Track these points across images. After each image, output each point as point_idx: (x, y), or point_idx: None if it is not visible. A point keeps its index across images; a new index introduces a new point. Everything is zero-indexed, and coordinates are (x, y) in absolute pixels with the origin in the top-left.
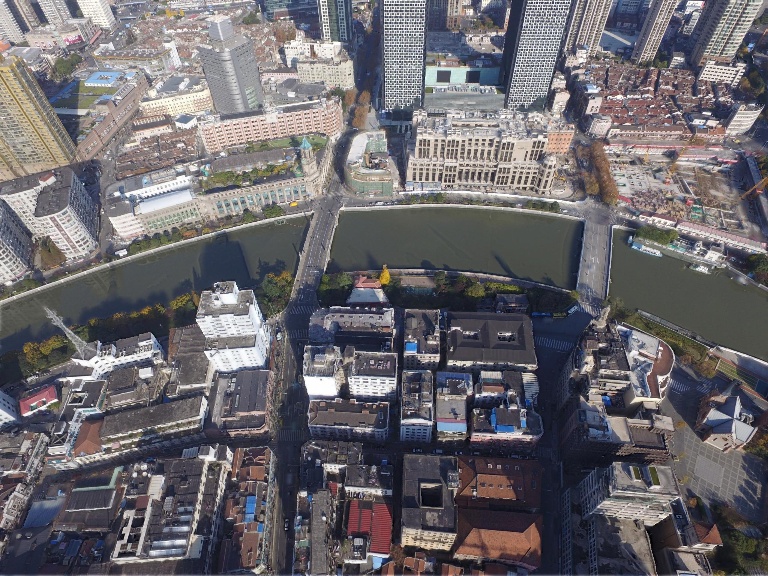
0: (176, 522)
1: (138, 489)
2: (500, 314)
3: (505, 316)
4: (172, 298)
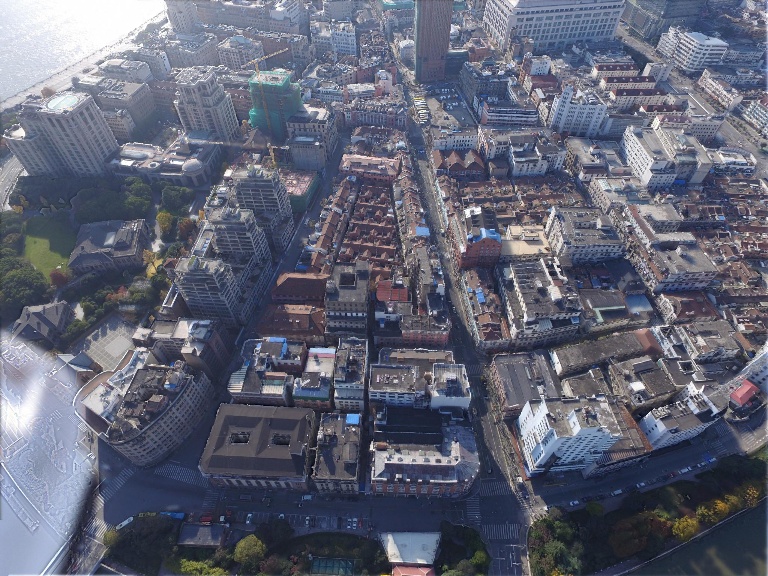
0: (527, 277)
1: (566, 288)
2: (235, 471)
3: (230, 467)
4: (714, 561)
